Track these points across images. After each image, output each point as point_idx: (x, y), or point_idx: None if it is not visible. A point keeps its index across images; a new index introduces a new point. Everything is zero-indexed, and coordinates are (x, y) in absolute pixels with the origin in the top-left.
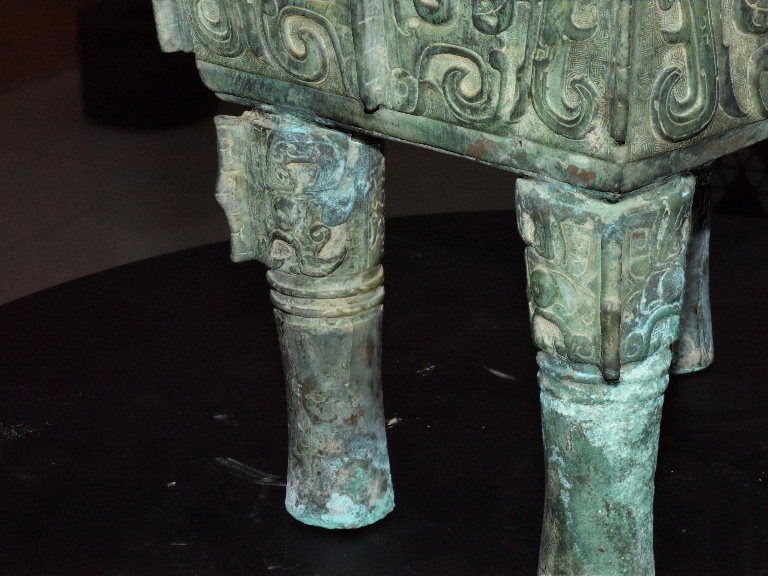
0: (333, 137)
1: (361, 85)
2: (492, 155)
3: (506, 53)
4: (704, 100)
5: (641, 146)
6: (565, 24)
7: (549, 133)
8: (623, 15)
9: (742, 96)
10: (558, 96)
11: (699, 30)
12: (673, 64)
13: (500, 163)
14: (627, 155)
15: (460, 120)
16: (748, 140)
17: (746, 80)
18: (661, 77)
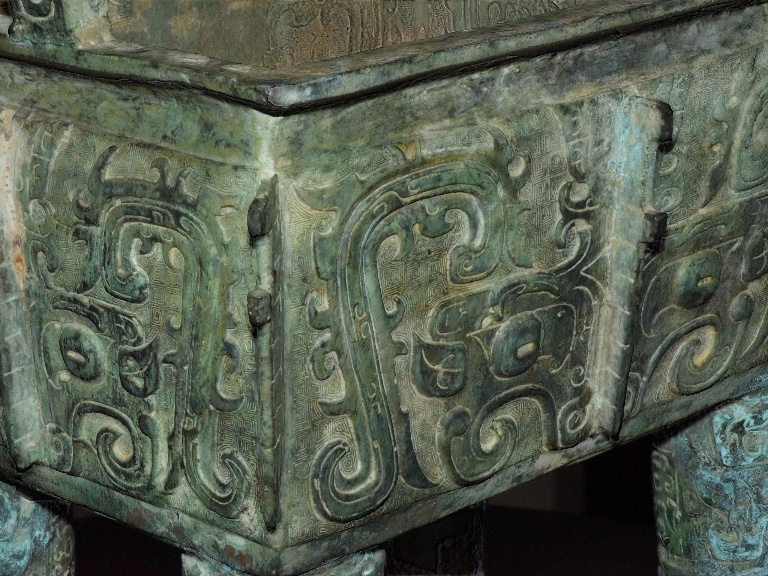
0: (3, 485)
1: (10, 442)
2: (150, 526)
3: (156, 418)
4: (379, 474)
5: (301, 529)
6: (211, 393)
7: (204, 508)
8: (264, 391)
9: (430, 465)
10: (210, 470)
11: (367, 399)
12: (337, 437)
13: (159, 535)
14: (284, 539)
15: (115, 485)
16: (444, 510)
17: (434, 447)
18: (321, 453)
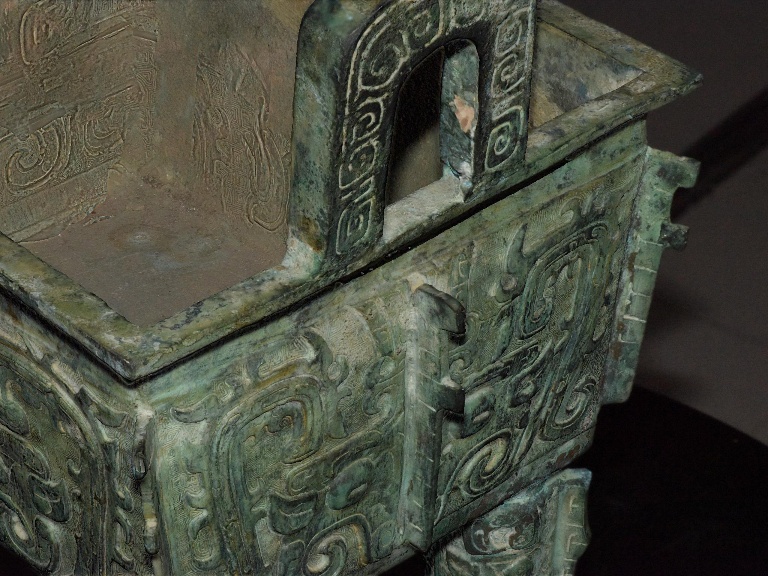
0: None
1: None
2: None
3: None
4: None
5: None
6: None
7: (545, 445)
8: None
9: None
10: None
11: None
12: None
13: None
14: None
15: None
16: None
17: None
18: None
